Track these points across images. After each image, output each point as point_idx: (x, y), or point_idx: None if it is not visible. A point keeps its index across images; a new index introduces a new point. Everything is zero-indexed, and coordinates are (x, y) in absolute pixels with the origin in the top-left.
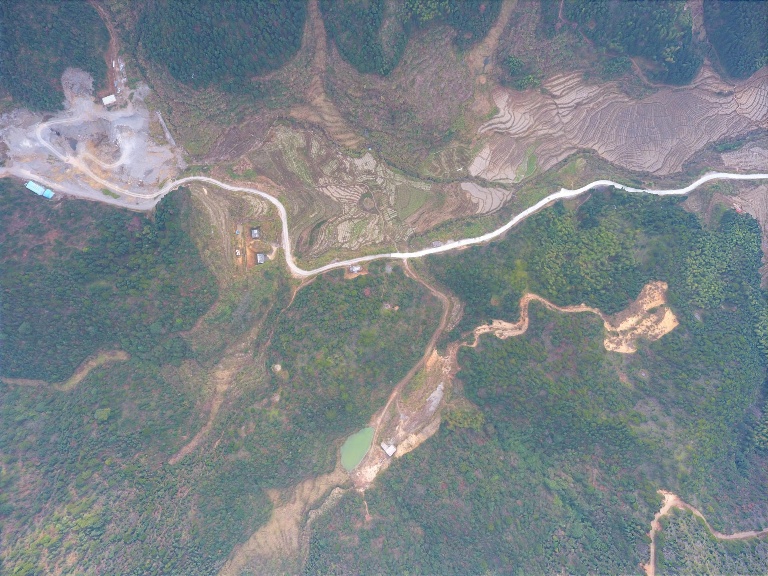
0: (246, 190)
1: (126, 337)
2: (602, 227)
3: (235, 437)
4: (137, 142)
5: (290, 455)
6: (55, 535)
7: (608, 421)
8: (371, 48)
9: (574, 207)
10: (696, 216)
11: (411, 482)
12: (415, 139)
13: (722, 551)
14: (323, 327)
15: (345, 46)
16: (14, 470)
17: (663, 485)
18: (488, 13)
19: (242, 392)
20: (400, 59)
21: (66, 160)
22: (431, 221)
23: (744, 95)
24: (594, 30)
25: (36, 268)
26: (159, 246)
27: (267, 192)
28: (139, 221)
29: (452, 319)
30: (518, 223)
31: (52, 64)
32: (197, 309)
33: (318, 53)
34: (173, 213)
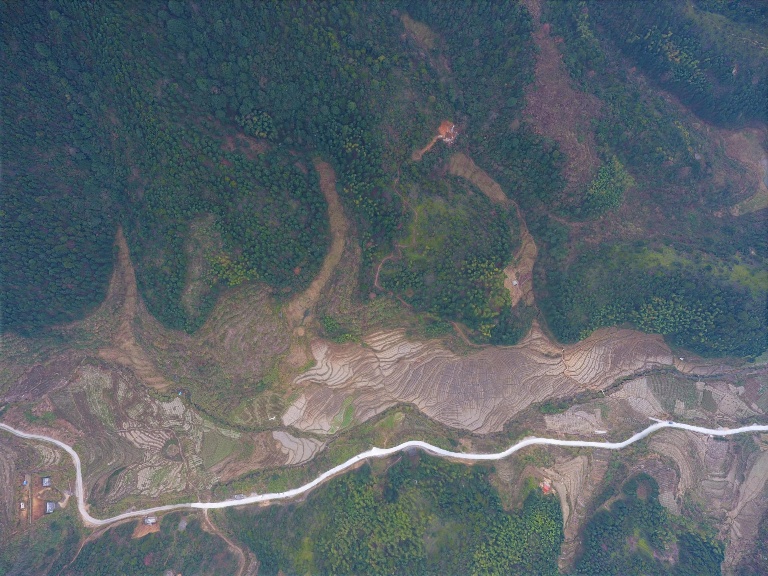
0: (40, 437)
1: None
2: (399, 505)
3: None
4: None
5: None
6: None
7: None
8: (173, 311)
9: (384, 467)
10: (498, 497)
11: None
12: (225, 389)
13: None
14: None
15: (150, 302)
16: None
17: None
18: (306, 271)
19: None
20: (208, 317)
21: None
22: (237, 470)
23: (573, 357)
24: (411, 299)
25: None
26: None
27: (61, 441)
28: None
29: None
30: (322, 484)
31: None
32: None
33: (128, 299)
34: None
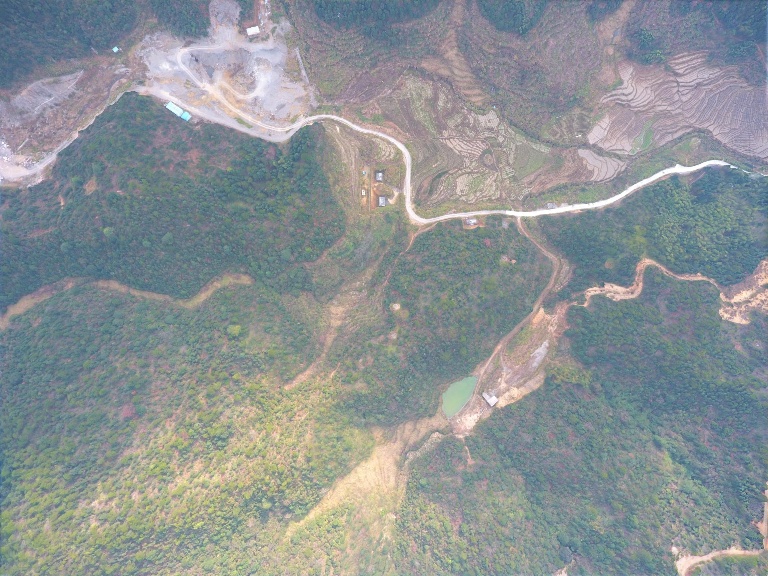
0: (375, 133)
1: (256, 260)
2: (719, 203)
3: (353, 368)
4: (273, 76)
5: (402, 392)
6: (186, 440)
7: (728, 383)
8: (514, 5)
9: (687, 183)
10: None
11: (516, 430)
12: (540, 101)
13: None
14: (447, 270)
15: (487, 2)
16: (148, 374)
17: None
18: None
19: (358, 327)
20: (538, 20)
21: (202, 86)
22: (547, 183)
23: None
24: (727, 11)
25: (185, 181)
26: (293, 176)
27: (395, 137)
28: (274, 151)
29: (560, 280)
30: (633, 193)
31: None
32: (326, 241)
33: (456, 7)
34: (310, 145)
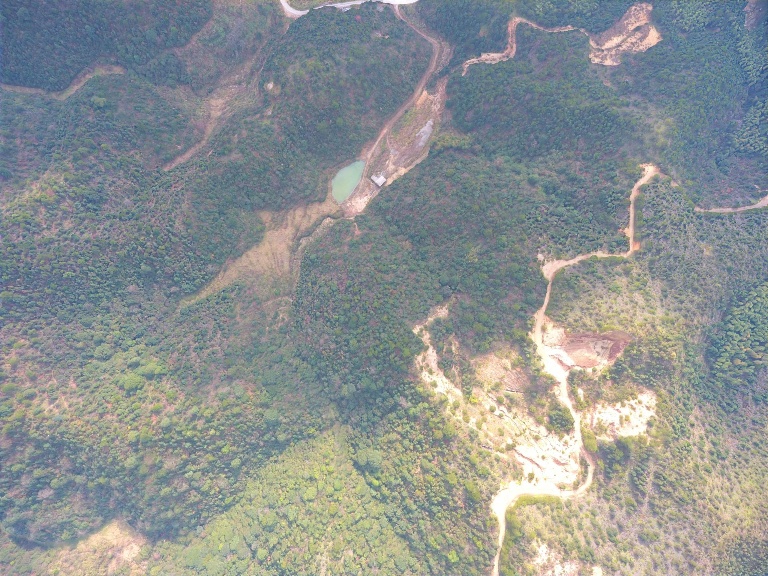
0: None
1: (122, 44)
2: None
3: (228, 142)
4: None
5: (282, 167)
6: (52, 197)
7: (591, 105)
8: None
9: None
10: None
11: (400, 196)
12: None
13: (700, 214)
14: (315, 40)
15: None
16: (12, 144)
17: (643, 158)
18: None
19: (235, 111)
20: None
21: None
22: None
23: None
24: None
25: None
26: None
27: None
28: None
29: (442, 62)
30: None
31: None
32: (192, 21)
33: None
34: None
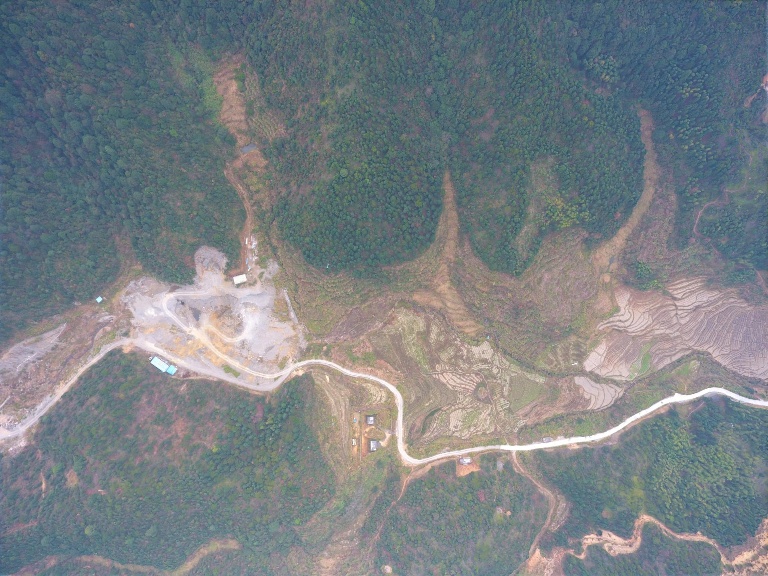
0: (366, 376)
1: (243, 533)
2: (719, 447)
3: None
4: (261, 318)
5: None
6: None
7: None
8: (507, 252)
9: (686, 413)
10: None
11: None
12: (535, 333)
13: None
14: (440, 537)
15: (479, 244)
16: None
17: None
18: (621, 217)
19: None
20: None
21: (189, 331)
22: (542, 414)
23: None
24: (726, 245)
25: (169, 473)
26: (281, 438)
27: (386, 380)
28: (262, 409)
29: (557, 518)
30: (631, 428)
31: (189, 244)
32: (315, 508)
33: (448, 243)
34: (299, 407)
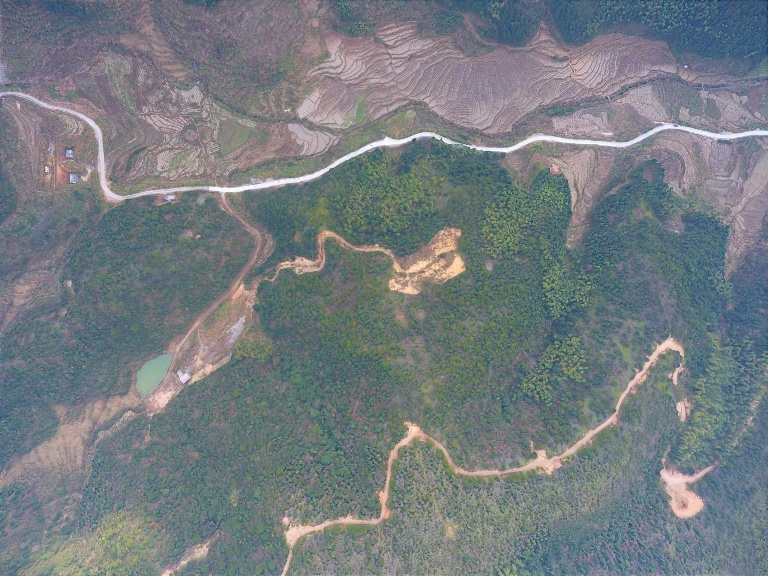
0: (63, 110)
1: None
2: (411, 174)
3: (13, 346)
4: None
5: (72, 370)
6: None
7: (366, 352)
8: None
9: (396, 156)
10: (508, 171)
11: (191, 406)
12: (242, 75)
13: (455, 484)
14: (113, 245)
15: None
16: None
17: (409, 417)
18: None
19: (33, 305)
20: None
21: None
22: (254, 158)
23: (580, 62)
24: None
25: None
26: None
27: (84, 113)
28: None
29: (263, 256)
30: (336, 166)
31: None
32: None
33: None
34: None
